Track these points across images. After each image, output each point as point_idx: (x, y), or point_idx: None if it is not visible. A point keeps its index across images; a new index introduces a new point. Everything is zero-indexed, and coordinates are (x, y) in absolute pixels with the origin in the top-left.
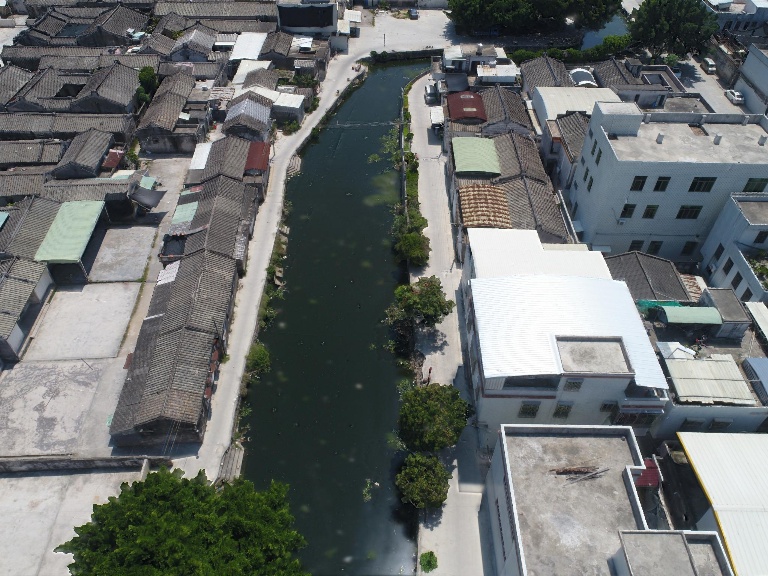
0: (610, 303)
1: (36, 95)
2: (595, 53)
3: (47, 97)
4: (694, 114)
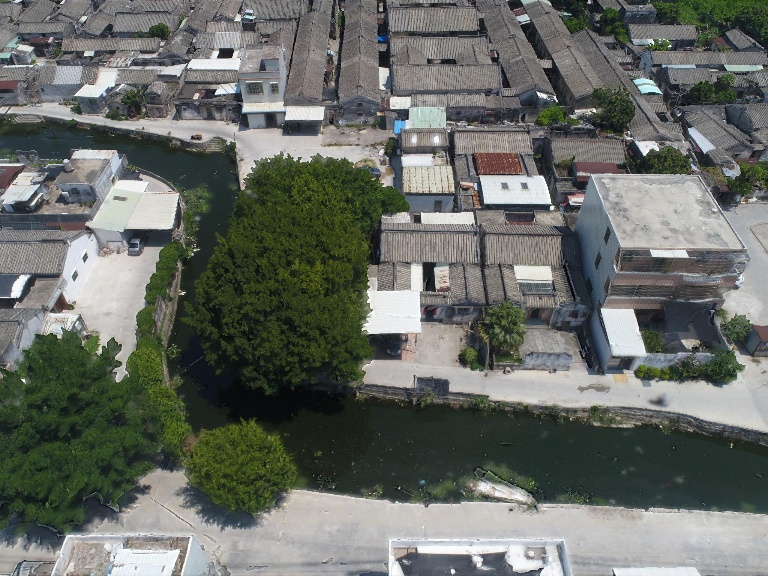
0: None
1: (143, 4)
2: (138, 347)
3: (137, 7)
4: None
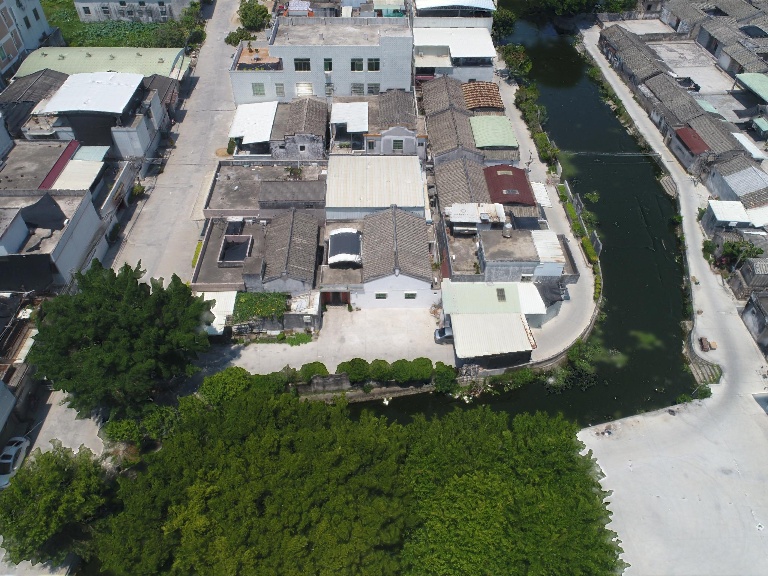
0: (429, 0)
1: None
2: None
3: None
4: (327, 46)
